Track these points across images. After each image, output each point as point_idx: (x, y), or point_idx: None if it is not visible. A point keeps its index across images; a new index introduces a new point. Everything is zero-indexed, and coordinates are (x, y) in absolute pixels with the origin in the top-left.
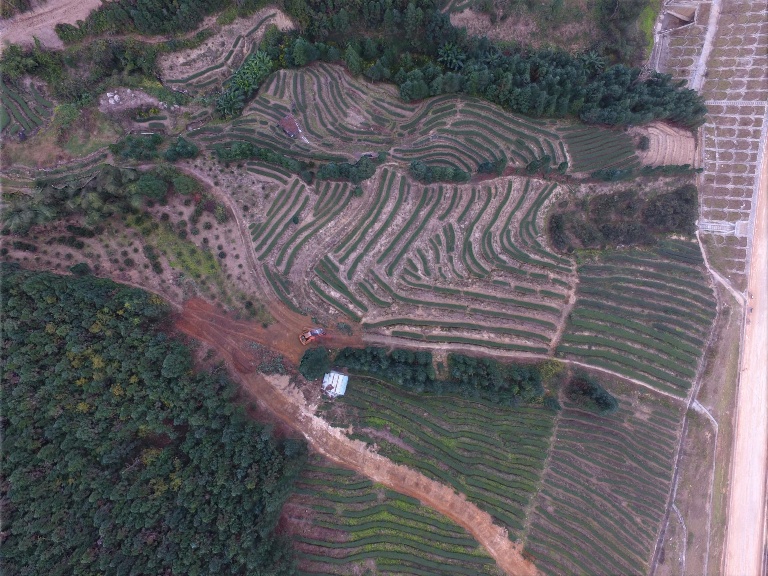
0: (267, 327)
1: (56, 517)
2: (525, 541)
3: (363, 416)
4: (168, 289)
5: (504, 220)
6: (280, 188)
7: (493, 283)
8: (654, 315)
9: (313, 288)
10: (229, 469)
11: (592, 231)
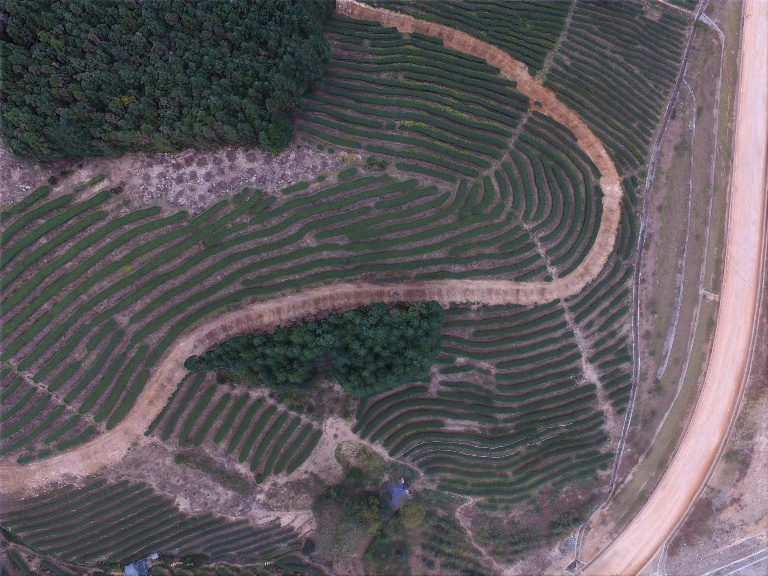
0: None
1: None
2: (544, 79)
3: None
4: None
5: None
6: None
7: None
8: None
9: None
10: None
11: None
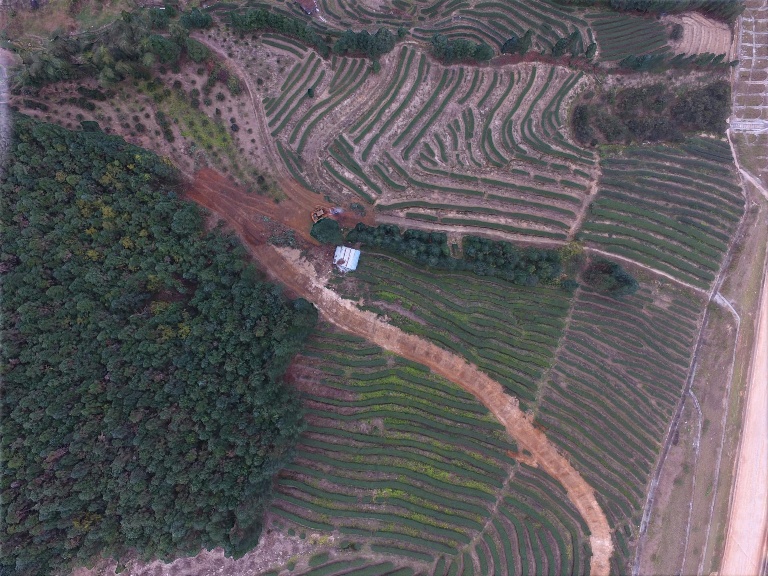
0: (279, 203)
1: (64, 350)
2: (536, 412)
3: (374, 290)
4: (179, 158)
5: (526, 109)
6: (295, 62)
7: (512, 172)
8: (679, 208)
9: (327, 168)
10: (238, 320)
11: (617, 124)
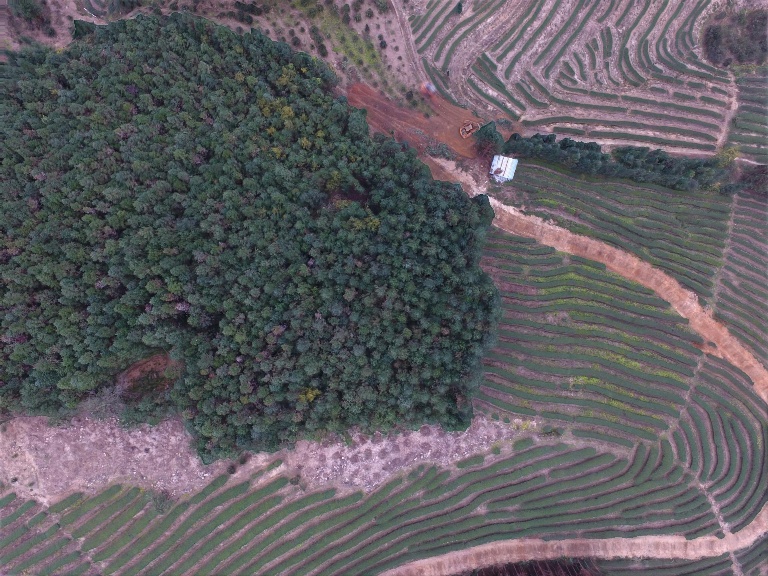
0: (429, 117)
1: (269, 235)
2: (714, 308)
3: (534, 198)
4: None
5: (661, 29)
6: None
7: (650, 90)
8: None
9: (470, 86)
10: (426, 213)
11: (750, 44)
